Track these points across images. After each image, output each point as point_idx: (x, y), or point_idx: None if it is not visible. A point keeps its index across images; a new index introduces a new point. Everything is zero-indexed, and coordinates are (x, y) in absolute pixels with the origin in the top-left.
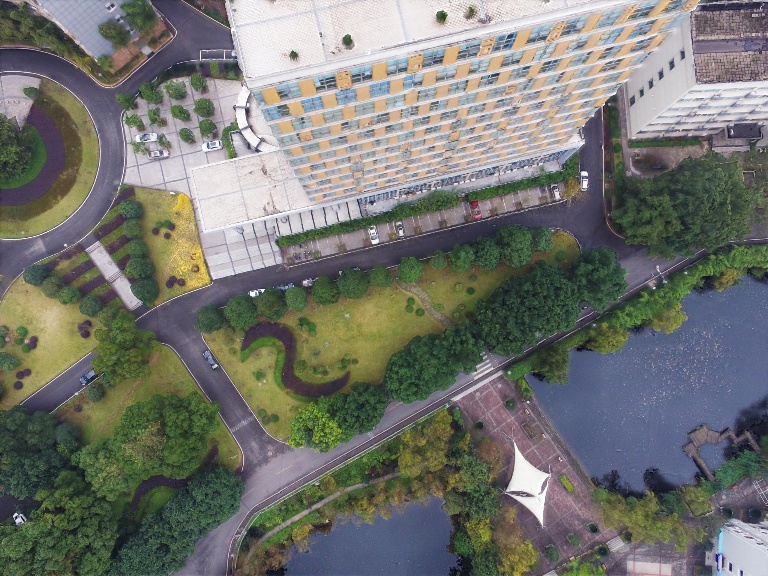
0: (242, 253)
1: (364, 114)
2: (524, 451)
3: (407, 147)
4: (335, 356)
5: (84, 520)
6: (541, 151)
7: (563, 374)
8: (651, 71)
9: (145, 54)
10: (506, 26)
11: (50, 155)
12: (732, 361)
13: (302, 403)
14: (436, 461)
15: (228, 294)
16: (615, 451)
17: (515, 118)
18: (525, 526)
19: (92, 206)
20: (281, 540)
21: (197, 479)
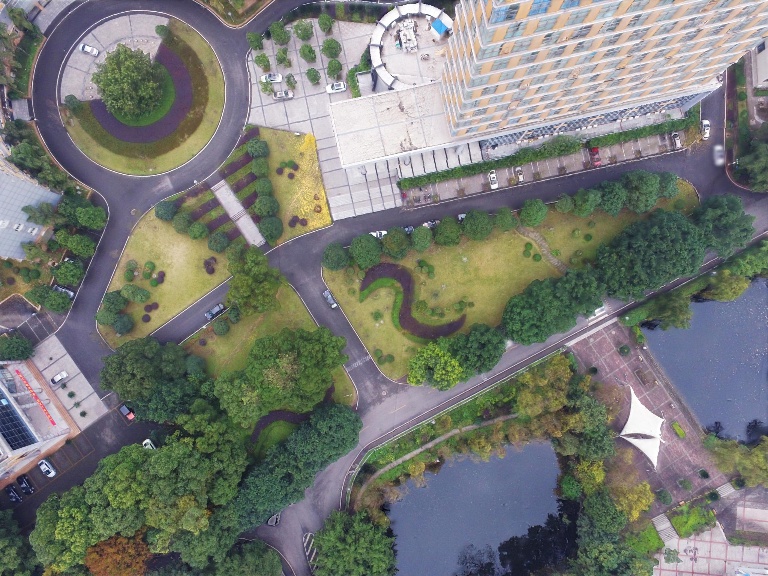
0: (363, 195)
1: (572, 24)
2: None
3: (576, 73)
4: (452, 299)
5: (218, 446)
6: (679, 92)
7: (686, 318)
8: None
9: None
10: None
11: (178, 94)
12: None
13: (418, 344)
14: (557, 401)
15: (348, 235)
16: (726, 400)
17: (688, 44)
18: None
19: (217, 145)
20: (393, 477)
21: (319, 413)
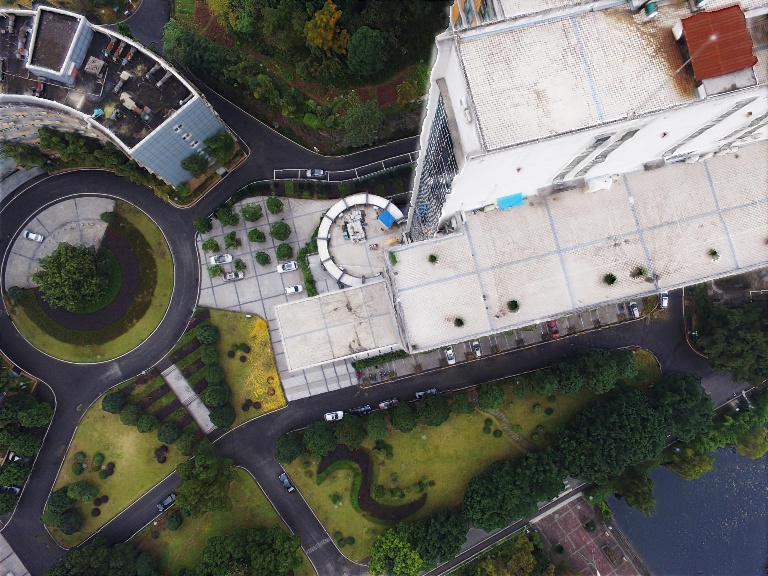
0: (318, 375)
1: None
2: (604, 574)
3: None
4: (412, 478)
5: None
6: None
7: (650, 506)
8: None
9: (219, 174)
10: None
11: (125, 278)
12: None
13: (378, 525)
14: None
15: (304, 416)
16: (697, 573)
17: None
18: None
19: (167, 329)
20: None
21: None
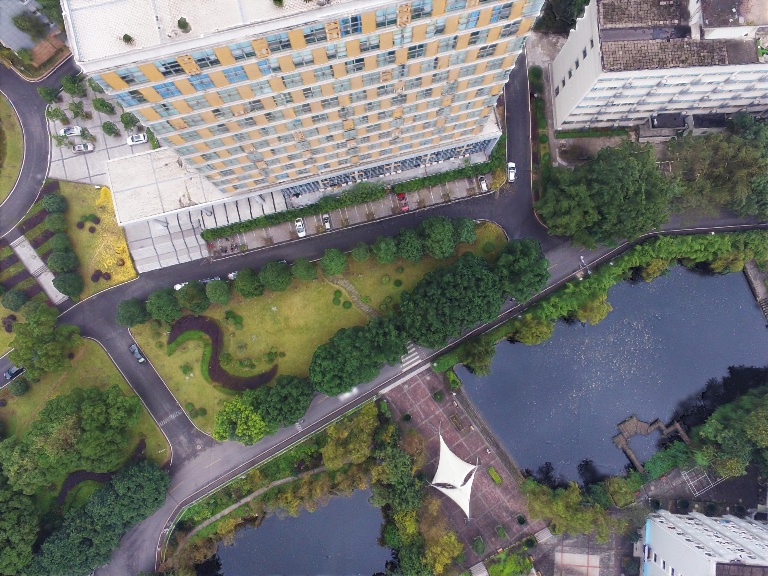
0: (168, 246)
1: (232, 101)
2: (452, 443)
3: (301, 136)
4: (262, 349)
5: (2, 514)
6: (458, 141)
7: (485, 365)
8: (570, 61)
9: None
10: (343, 8)
11: None
12: (662, 352)
13: (230, 396)
14: (358, 453)
15: (154, 288)
16: (544, 443)
17: (408, 106)
18: (453, 518)
19: (17, 200)
20: (210, 534)
21: (121, 473)
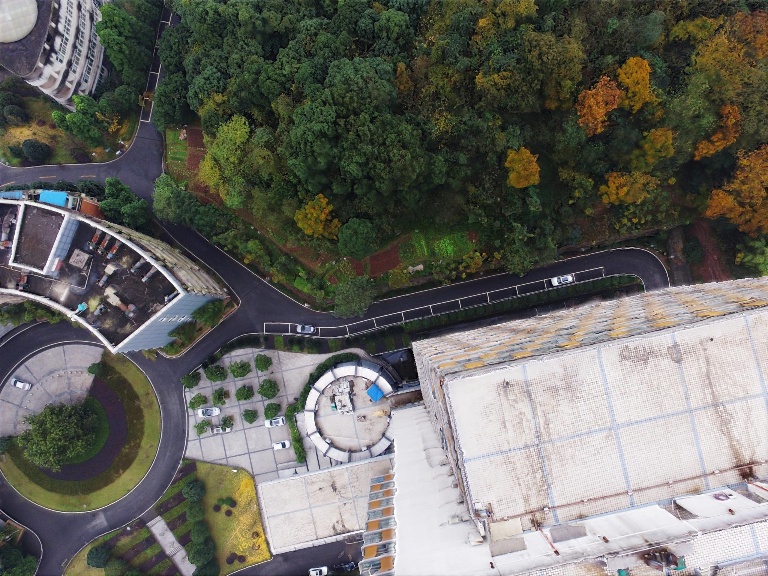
0: None
1: None
2: None
3: None
4: None
5: None
6: None
7: None
8: None
9: None
10: None
11: (113, 429)
12: None
13: None
14: None
15: (288, 570)
16: None
17: None
18: None
19: (154, 480)
20: None
21: None
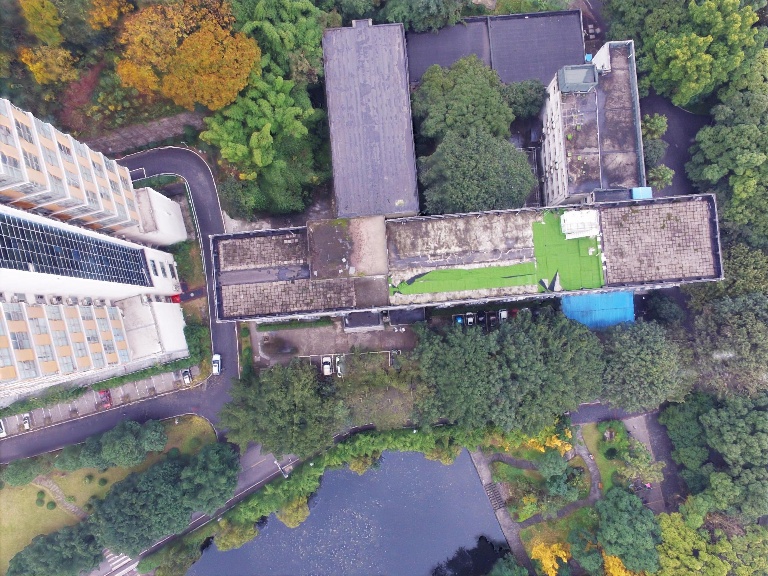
0: None
1: None
2: None
3: None
4: None
5: None
6: (115, 366)
7: None
8: None
9: None
10: None
11: None
12: (382, 541)
13: None
14: None
15: None
16: None
17: None
18: None
19: None
20: None
21: None
